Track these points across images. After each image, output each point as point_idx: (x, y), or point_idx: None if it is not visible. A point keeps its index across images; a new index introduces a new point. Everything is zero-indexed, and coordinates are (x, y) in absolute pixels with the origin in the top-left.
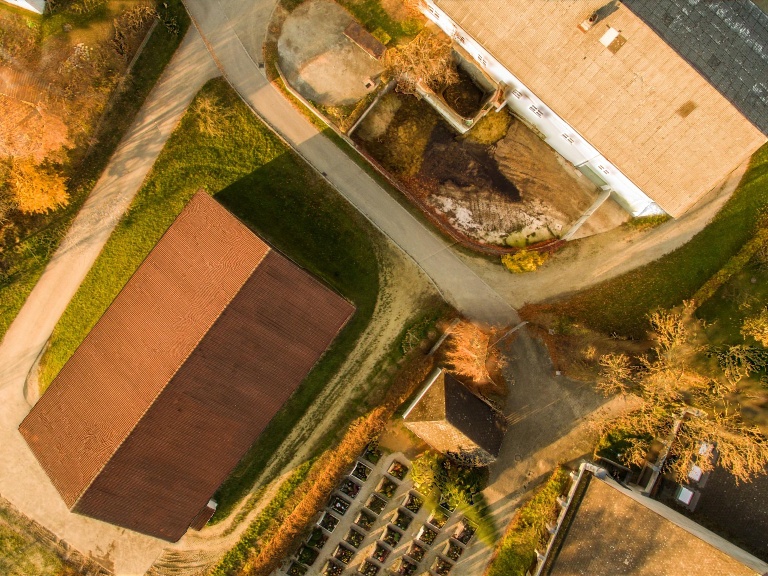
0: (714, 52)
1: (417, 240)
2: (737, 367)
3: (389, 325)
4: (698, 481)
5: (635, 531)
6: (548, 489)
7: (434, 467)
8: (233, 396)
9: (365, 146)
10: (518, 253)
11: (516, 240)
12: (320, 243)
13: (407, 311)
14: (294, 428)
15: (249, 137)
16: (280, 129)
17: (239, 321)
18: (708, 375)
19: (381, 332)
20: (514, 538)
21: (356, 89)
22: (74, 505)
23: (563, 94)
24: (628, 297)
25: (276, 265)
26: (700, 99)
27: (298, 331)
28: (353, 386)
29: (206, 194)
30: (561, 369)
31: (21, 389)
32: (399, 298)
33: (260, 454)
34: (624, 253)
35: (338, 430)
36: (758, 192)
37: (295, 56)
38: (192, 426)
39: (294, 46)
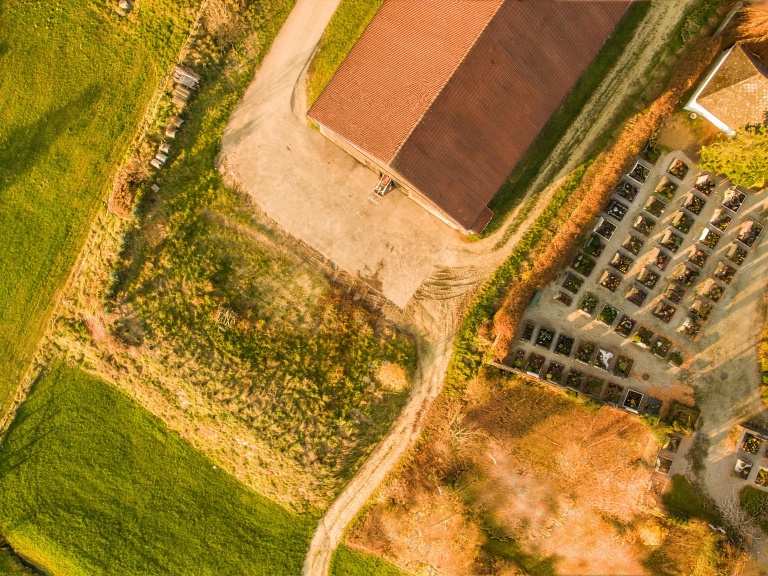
0: None
1: None
2: None
3: (668, 12)
4: None
5: None
6: None
7: (740, 135)
8: (538, 57)
9: None
10: None
11: None
12: None
13: None
14: (568, 129)
15: None
16: None
17: None
18: None
19: (659, 20)
20: None
21: None
22: (393, 158)
23: None
24: None
25: None
26: None
27: None
28: (630, 81)
29: None
30: None
31: (288, 100)
32: None
33: (534, 158)
34: None
35: (614, 130)
36: None
37: None
38: (500, 85)
39: None
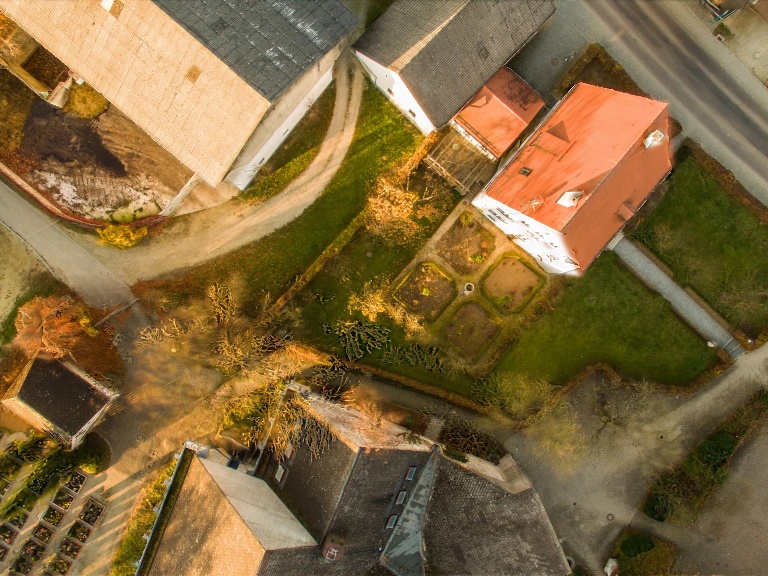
0: (223, 15)
1: (22, 216)
2: (358, 343)
3: None
4: (288, 458)
5: (206, 509)
6: (171, 469)
7: (20, 445)
8: None
9: None
10: (107, 228)
11: (123, 216)
12: None
13: (17, 289)
14: None
15: None
16: None
17: None
18: (328, 352)
19: None
20: (139, 519)
21: None
22: None
23: (86, 61)
24: (243, 273)
25: None
26: (202, 63)
27: None
28: None
29: None
30: (177, 347)
31: None
32: (8, 276)
33: None
34: (236, 228)
35: None
36: (365, 164)
37: None
38: None
39: None
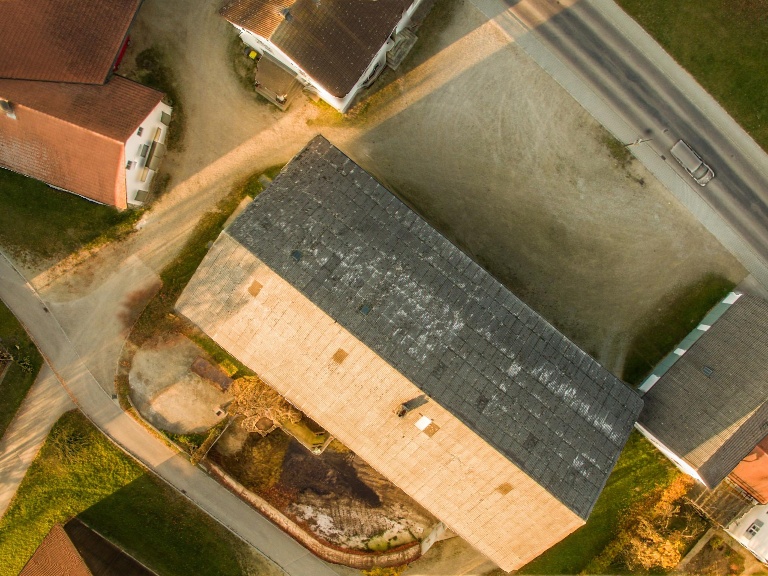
0: (532, 430)
1: (280, 546)
2: None
3: None
4: None
5: None
6: None
7: None
8: None
9: (223, 461)
10: (373, 570)
11: (378, 544)
12: (183, 555)
13: None
14: None
15: (107, 462)
16: (137, 453)
17: None
18: None
19: None
20: None
21: (207, 417)
22: None
23: (388, 462)
24: None
25: None
26: (516, 482)
27: None
28: None
29: (62, 530)
30: None
31: None
32: None
33: None
34: None
35: None
36: (618, 495)
37: (146, 388)
38: None
39: (145, 379)
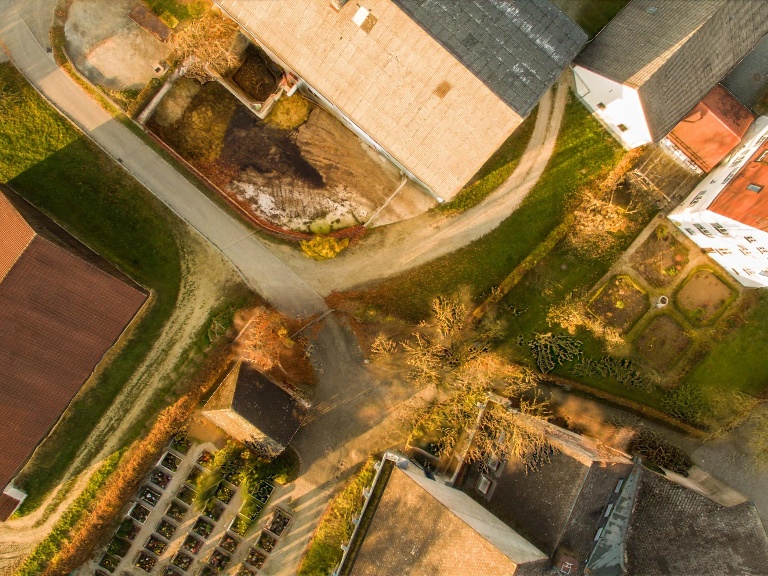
0: (472, 31)
1: (219, 227)
2: (550, 355)
3: (194, 313)
4: (495, 470)
5: (422, 521)
6: (360, 479)
7: (227, 456)
8: (14, 384)
9: (163, 132)
10: (313, 239)
11: (320, 227)
12: (118, 230)
13: (212, 299)
14: (102, 418)
15: (40, 123)
16: (72, 115)
17: (10, 308)
18: (520, 363)
19: (186, 320)
20: (327, 529)
21: (145, 73)
22: None
23: (326, 75)
24: (437, 284)
25: (45, 251)
26: (454, 79)
27: (82, 318)
28: (160, 375)
29: None
30: (370, 358)
31: None
32: (203, 286)
33: (68, 444)
34: (431, 240)
35: (147, 420)
36: (564, 177)
37: (82, 40)
38: None
39: (81, 30)
